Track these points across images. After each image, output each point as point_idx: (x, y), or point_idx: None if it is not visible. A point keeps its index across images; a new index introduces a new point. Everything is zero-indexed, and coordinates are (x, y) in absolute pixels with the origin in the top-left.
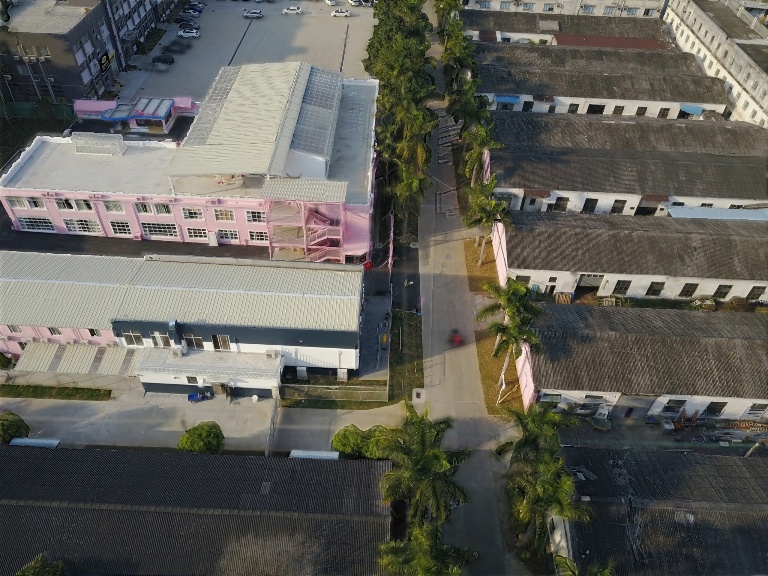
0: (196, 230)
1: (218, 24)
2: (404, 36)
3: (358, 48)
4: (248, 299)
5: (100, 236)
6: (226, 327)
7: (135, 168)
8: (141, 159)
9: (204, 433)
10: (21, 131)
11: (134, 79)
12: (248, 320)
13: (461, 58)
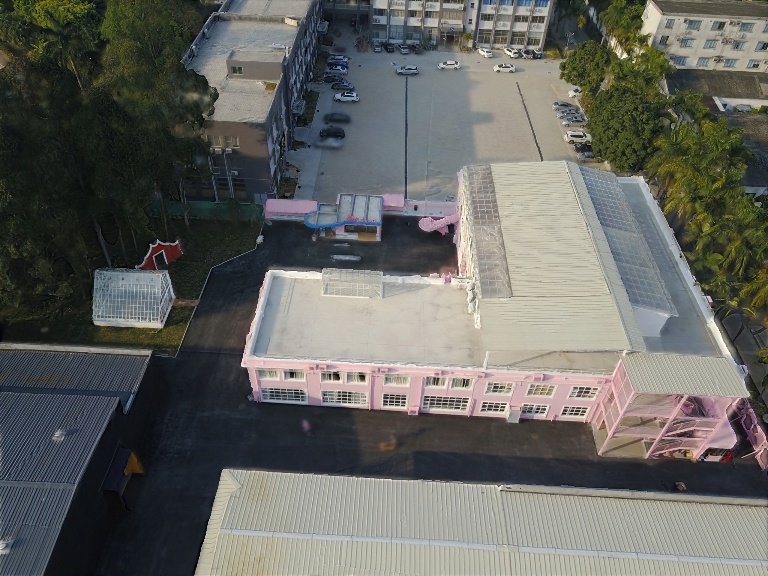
0: (493, 404)
1: (372, 83)
2: (653, 117)
3: (543, 114)
4: (687, 572)
5: (363, 408)
6: None
7: (408, 319)
8: (409, 304)
9: None
10: (203, 238)
11: (307, 160)
12: None
13: (734, 147)
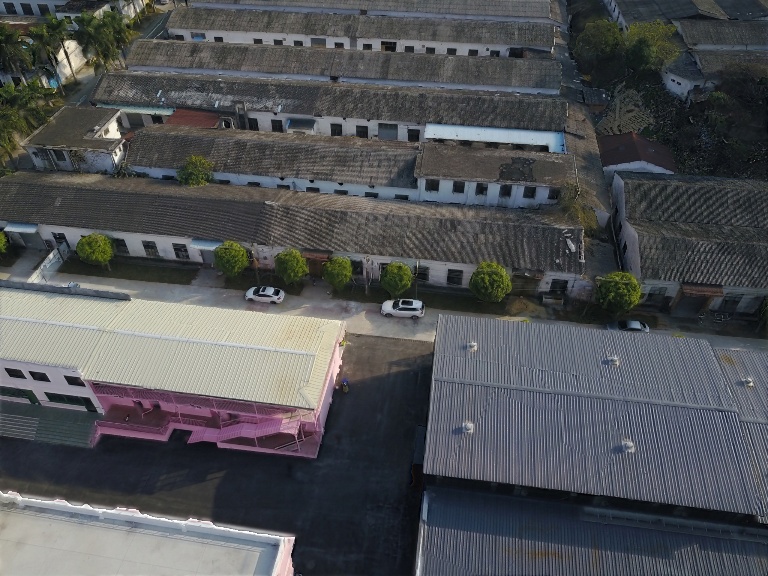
0: None
1: None
2: None
3: None
4: None
5: None
6: (29, 283)
7: None
8: None
9: (86, 238)
10: None
11: None
12: (7, 295)
13: None
